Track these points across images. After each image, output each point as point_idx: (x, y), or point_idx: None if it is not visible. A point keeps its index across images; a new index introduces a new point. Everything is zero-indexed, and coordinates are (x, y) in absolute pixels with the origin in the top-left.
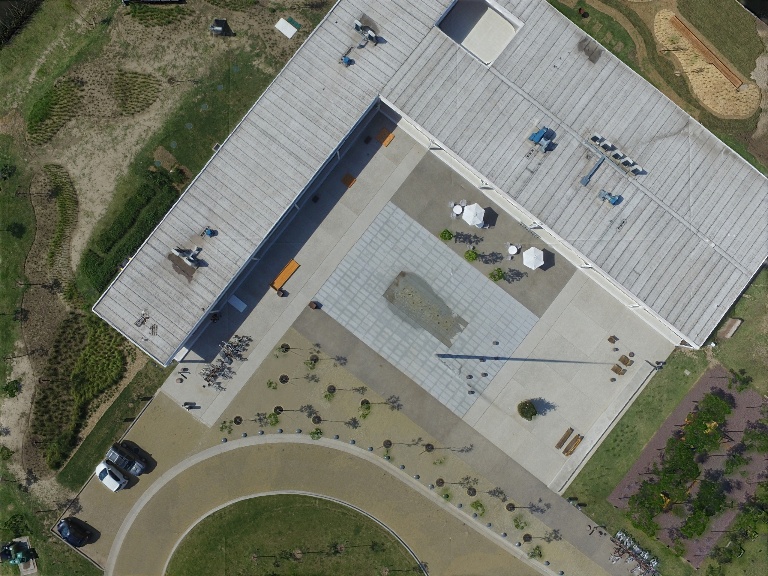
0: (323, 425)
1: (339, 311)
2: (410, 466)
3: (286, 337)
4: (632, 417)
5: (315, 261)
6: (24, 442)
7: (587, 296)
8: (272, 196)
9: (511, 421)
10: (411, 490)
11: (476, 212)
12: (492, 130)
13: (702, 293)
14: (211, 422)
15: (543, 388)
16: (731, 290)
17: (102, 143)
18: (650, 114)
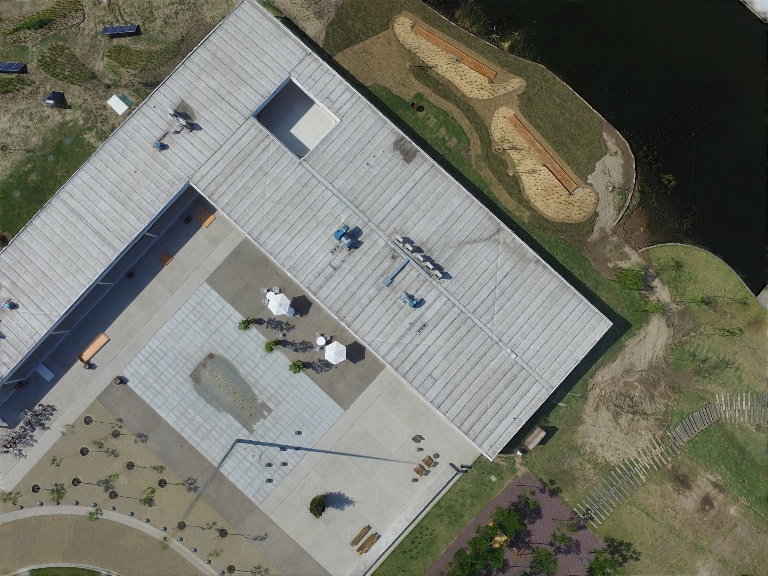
0: (119, 501)
1: (145, 388)
2: (202, 550)
3: (90, 409)
4: (433, 520)
5: (125, 336)
6: None
7: (395, 392)
8: (74, 274)
9: (308, 513)
10: (201, 574)
11: (280, 303)
12: (299, 224)
13: (499, 404)
14: (9, 488)
15: (343, 482)
16: (530, 403)
17: None
18: (460, 218)
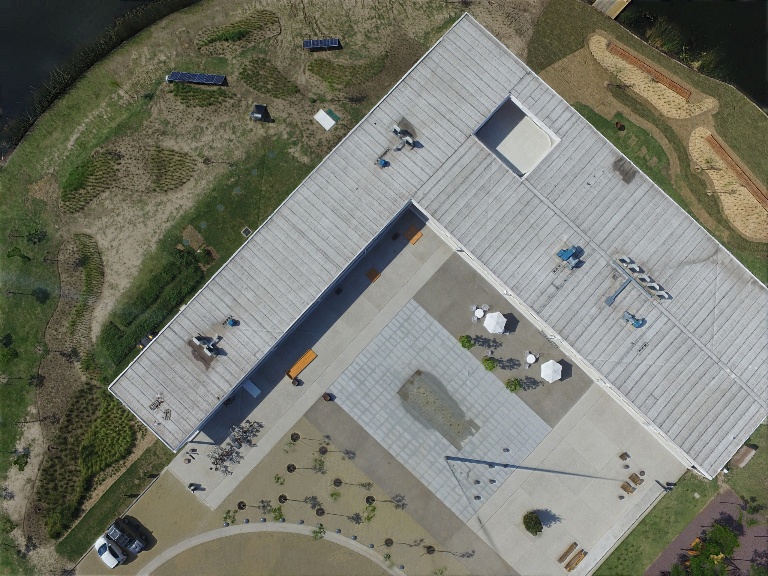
0: (326, 518)
1: (352, 404)
2: (410, 567)
3: (297, 426)
4: (638, 536)
5: (333, 352)
6: (27, 508)
7: (602, 410)
8: (297, 291)
9: (515, 530)
10: None
11: (498, 321)
12: (521, 243)
13: (719, 423)
14: (215, 505)
15: (550, 499)
16: (749, 423)
17: (133, 217)
18: (680, 239)
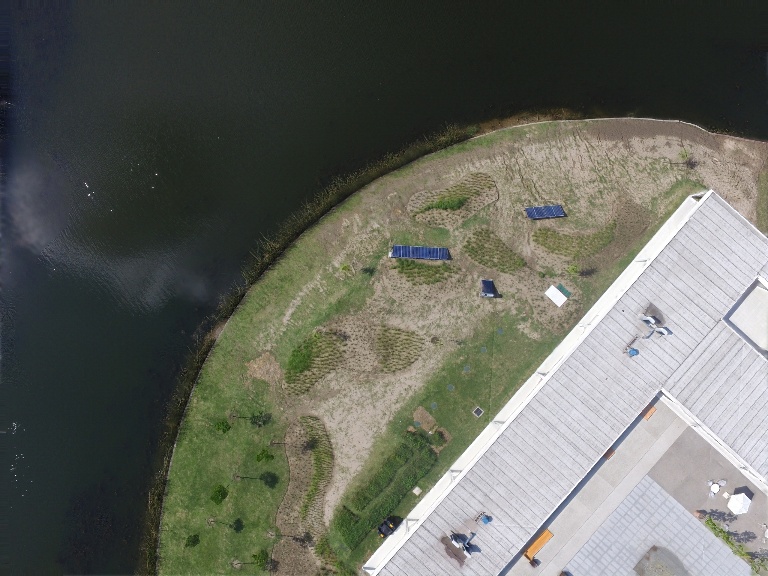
0: None
1: None
2: None
3: None
4: None
5: (569, 531)
6: None
7: None
8: (549, 485)
9: None
10: None
11: (744, 503)
12: None
13: None
14: None
15: None
16: None
17: (361, 398)
18: None
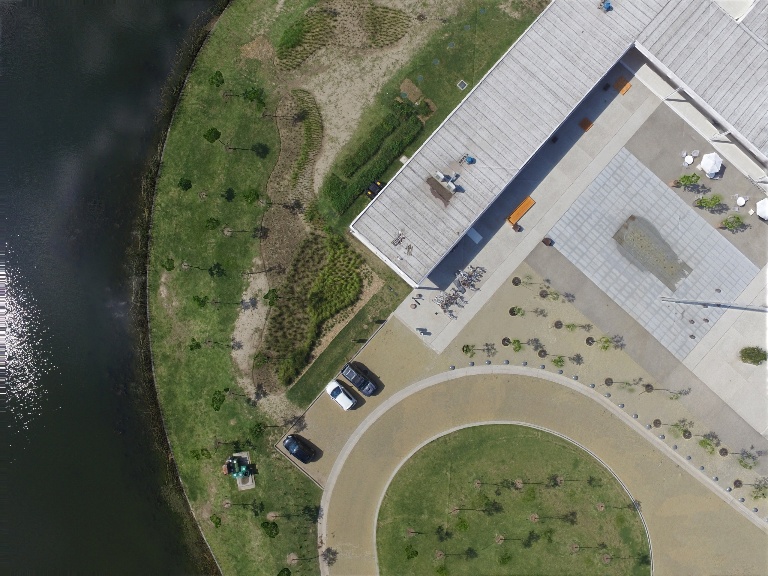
0: (548, 359)
1: (570, 249)
2: (629, 405)
3: (518, 271)
4: None
5: (550, 199)
6: None
7: None
8: (529, 129)
9: (728, 368)
10: (629, 429)
11: (715, 160)
12: (739, 82)
13: None
14: (440, 349)
15: (761, 338)
16: None
17: (350, 72)
18: None
